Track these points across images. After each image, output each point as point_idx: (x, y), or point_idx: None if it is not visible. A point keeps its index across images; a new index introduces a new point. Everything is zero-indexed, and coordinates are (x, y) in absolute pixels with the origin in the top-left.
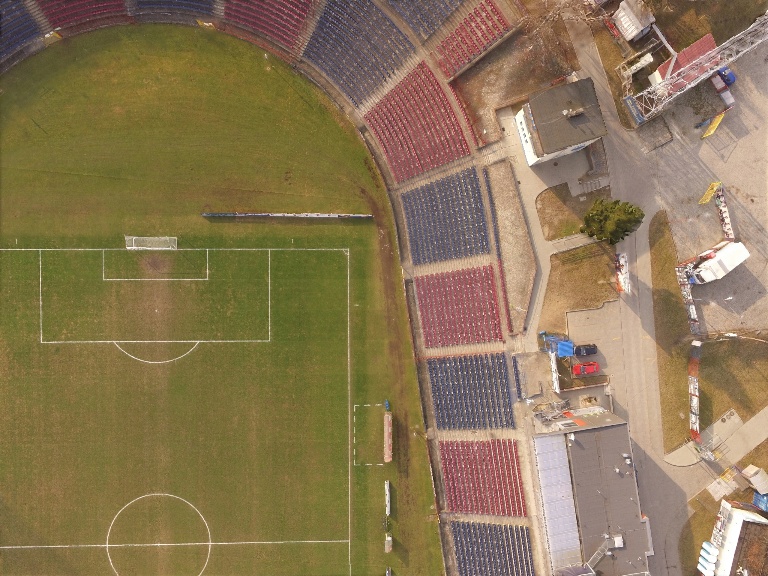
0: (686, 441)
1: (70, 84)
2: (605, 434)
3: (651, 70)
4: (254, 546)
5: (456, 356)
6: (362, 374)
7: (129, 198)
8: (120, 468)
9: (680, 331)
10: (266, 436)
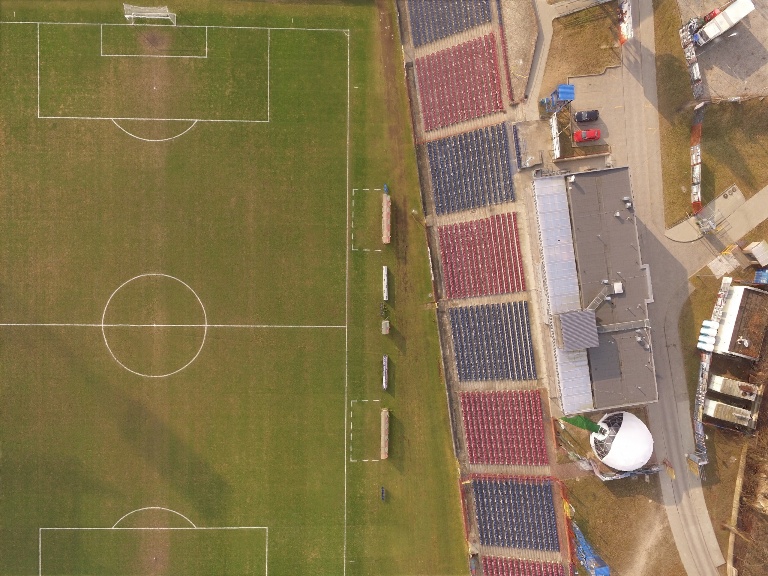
0: (687, 216)
1: None
2: (606, 179)
3: None
4: (250, 329)
5: (456, 135)
6: (361, 158)
7: None
8: (116, 247)
9: (683, 97)
10: (264, 218)
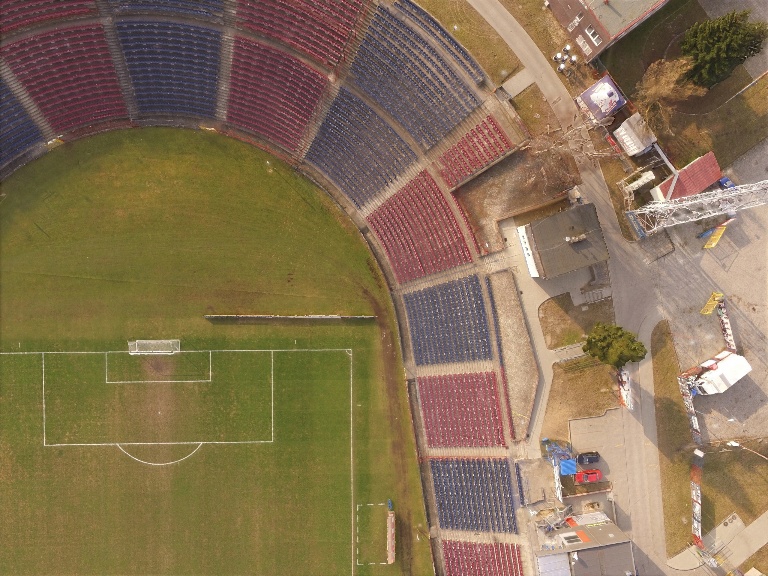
0: (689, 545)
1: (73, 188)
2: (608, 552)
3: (653, 184)
4: None
5: (459, 458)
6: (365, 474)
7: (132, 301)
8: (123, 570)
9: (682, 439)
10: (269, 536)
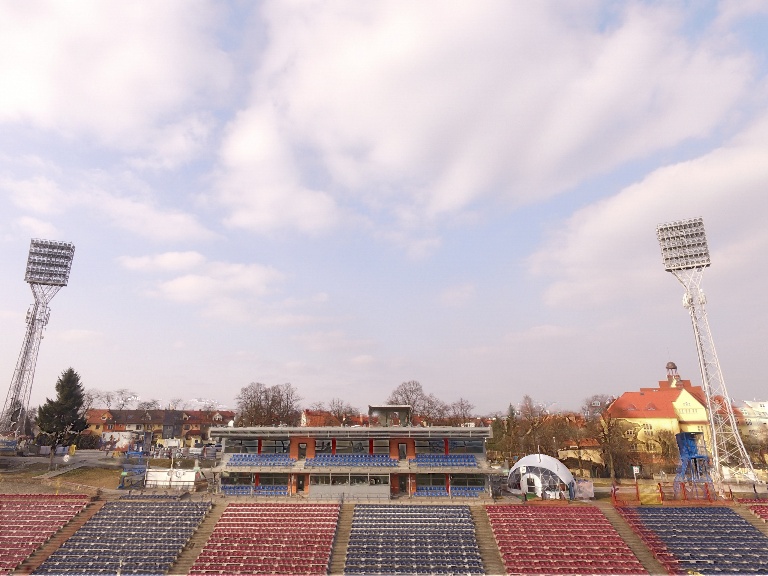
0: None
1: None
2: None
3: None
4: None
5: (54, 552)
6: None
7: None
8: None
9: (208, 462)
10: None
